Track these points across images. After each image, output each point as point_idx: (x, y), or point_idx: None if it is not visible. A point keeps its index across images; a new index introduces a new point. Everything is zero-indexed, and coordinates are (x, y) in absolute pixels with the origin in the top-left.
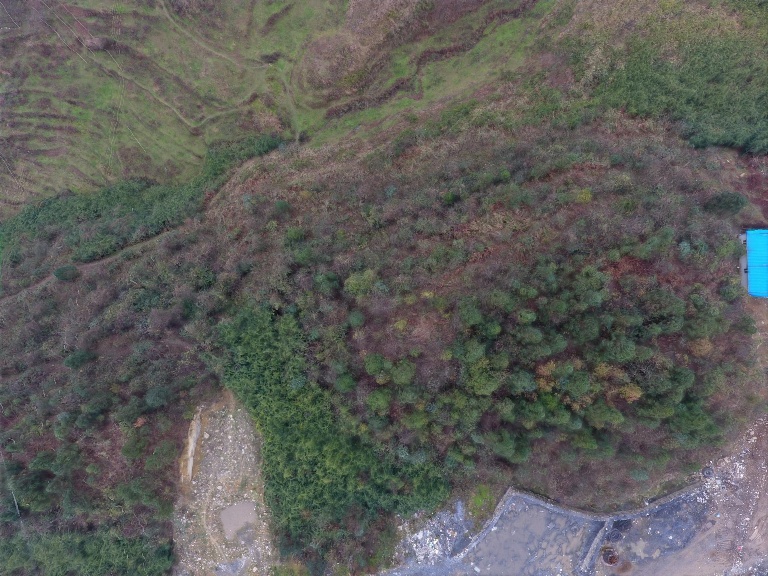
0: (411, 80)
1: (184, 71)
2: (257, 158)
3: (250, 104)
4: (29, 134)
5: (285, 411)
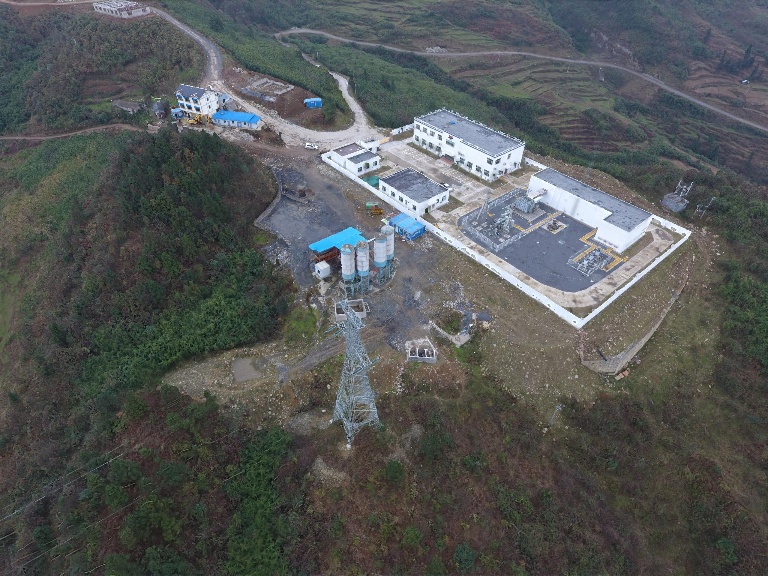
0: None
1: None
2: None
3: None
4: None
5: None
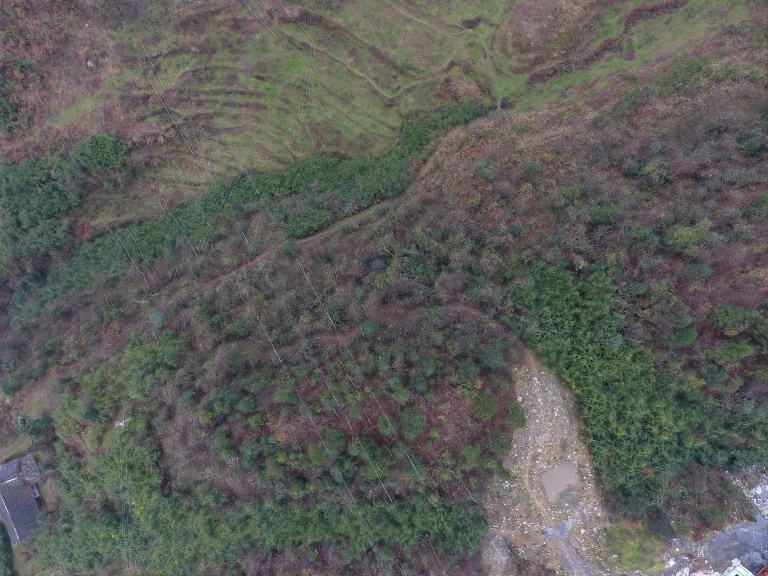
0: (618, 40)
1: (380, 40)
2: (461, 126)
3: (447, 72)
4: (215, 112)
5: (608, 370)
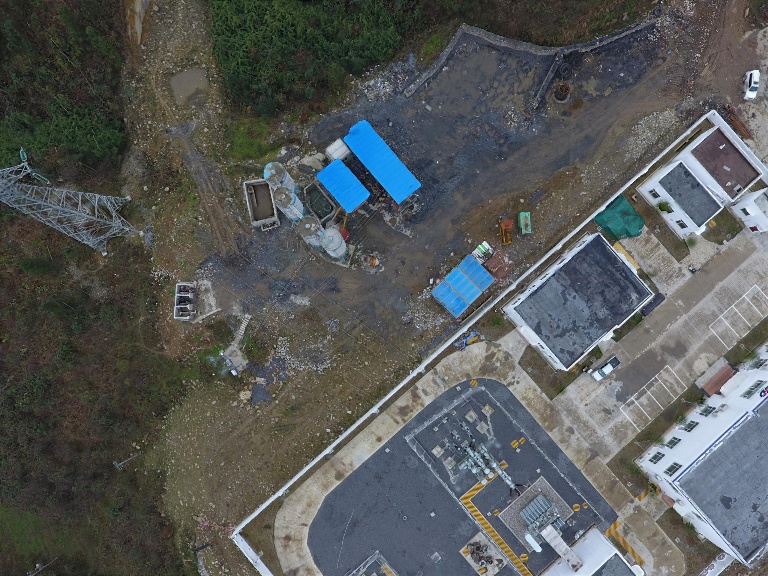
0: None
1: None
2: None
3: None
4: None
5: None
